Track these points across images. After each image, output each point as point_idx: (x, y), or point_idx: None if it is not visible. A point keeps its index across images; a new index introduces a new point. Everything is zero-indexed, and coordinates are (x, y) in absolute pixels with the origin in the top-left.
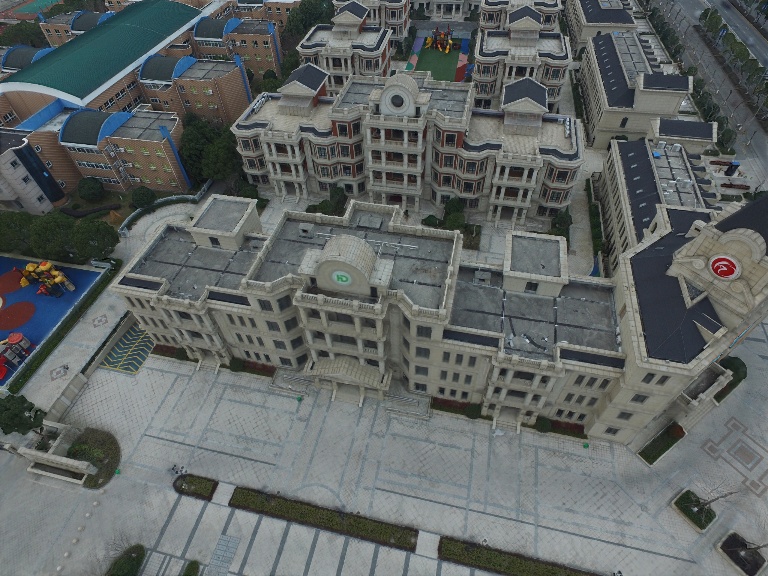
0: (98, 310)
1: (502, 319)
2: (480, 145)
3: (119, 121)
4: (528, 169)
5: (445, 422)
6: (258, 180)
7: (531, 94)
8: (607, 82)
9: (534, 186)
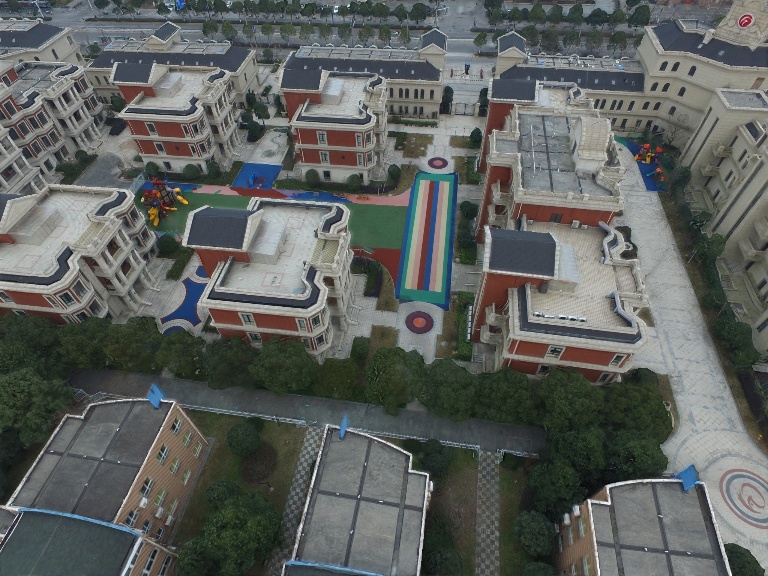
0: None
1: None
2: None
3: None
4: None
5: None
6: None
7: None
8: (394, 75)
9: None
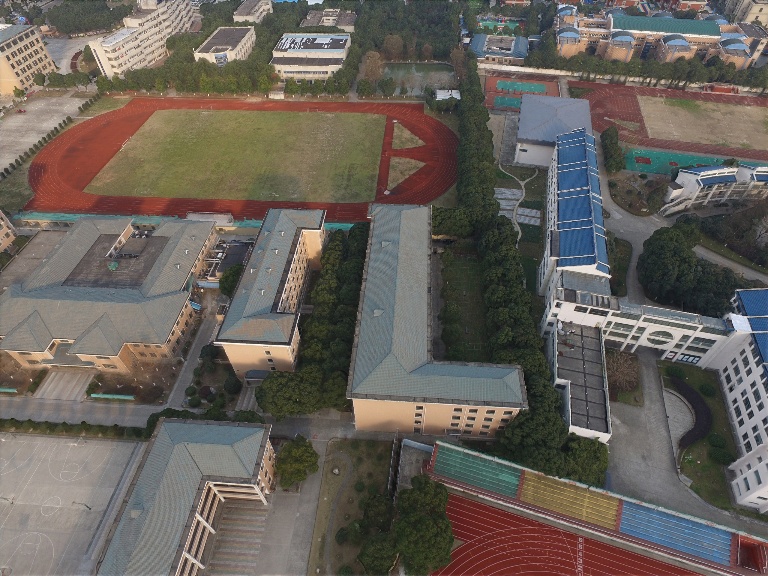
0: None
1: None
2: None
3: None
4: None
5: None
6: None
7: None
8: None
9: None
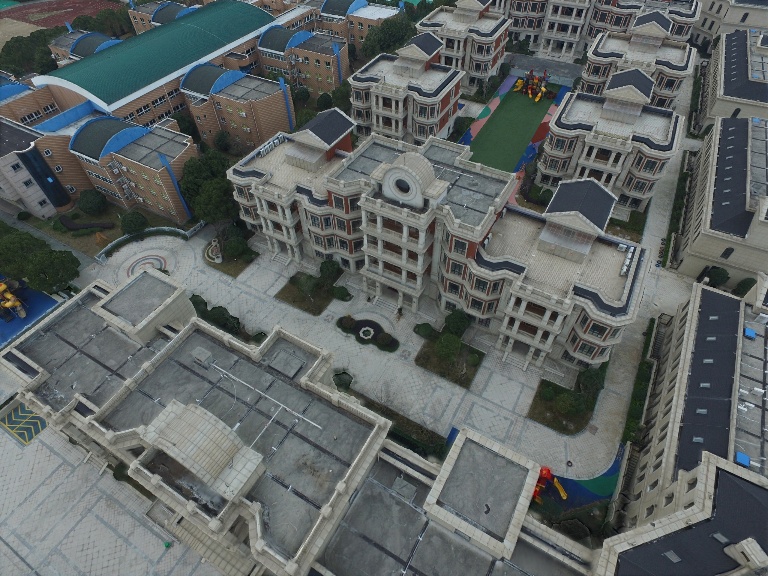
0: None
1: (403, 572)
2: (497, 262)
3: (131, 137)
4: (551, 311)
5: None
6: (256, 227)
7: (587, 206)
8: (720, 190)
9: (557, 332)
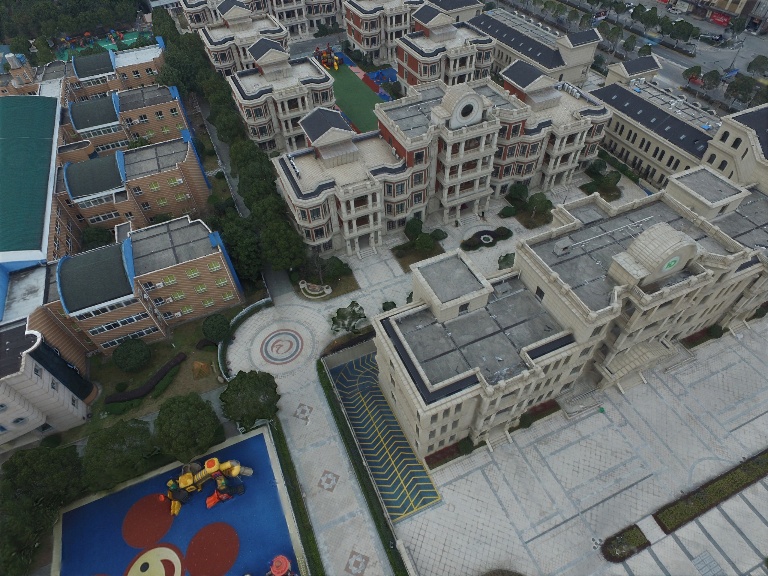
0: (311, 472)
1: None
2: (537, 127)
3: None
4: (581, 132)
5: (706, 353)
6: (318, 250)
7: None
8: (526, 51)
9: None
